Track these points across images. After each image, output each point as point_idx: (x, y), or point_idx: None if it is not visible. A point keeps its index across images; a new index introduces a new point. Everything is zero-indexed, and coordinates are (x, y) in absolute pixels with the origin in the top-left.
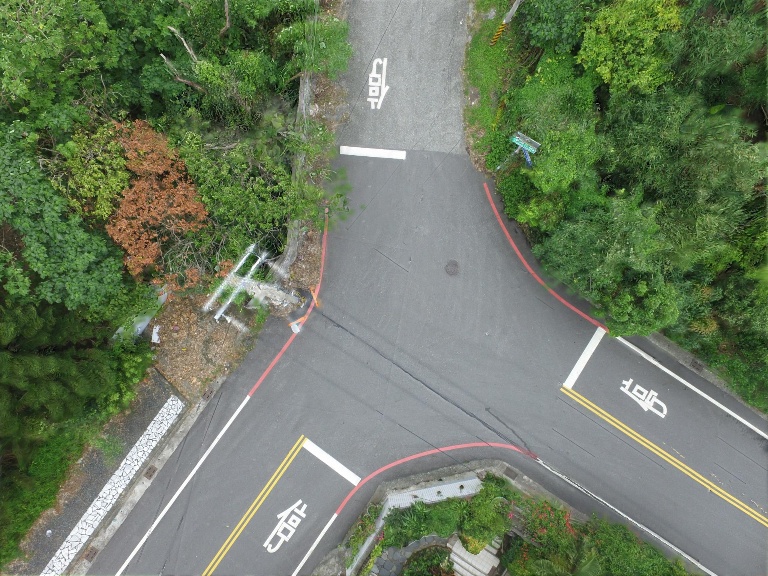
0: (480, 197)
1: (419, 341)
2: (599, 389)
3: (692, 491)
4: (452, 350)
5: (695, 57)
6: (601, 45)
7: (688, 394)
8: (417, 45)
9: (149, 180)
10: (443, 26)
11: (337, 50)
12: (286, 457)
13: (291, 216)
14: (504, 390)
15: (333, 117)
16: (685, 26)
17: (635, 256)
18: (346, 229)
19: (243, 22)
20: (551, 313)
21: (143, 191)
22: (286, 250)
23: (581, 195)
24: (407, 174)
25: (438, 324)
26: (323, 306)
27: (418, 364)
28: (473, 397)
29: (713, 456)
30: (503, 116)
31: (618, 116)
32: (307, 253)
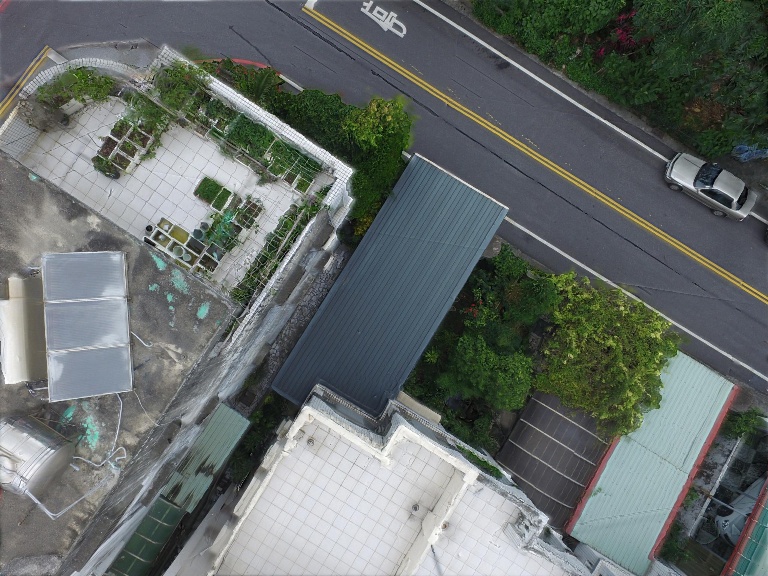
0: None
1: None
2: (340, 10)
3: (430, 105)
4: None
5: None
6: None
7: (427, 16)
8: None
9: None
10: None
11: None
12: (30, 64)
13: None
14: (247, 10)
15: None
16: None
17: None
18: None
19: None
20: None
21: None
22: None
23: None
24: None
25: None
26: None
27: None
28: (217, 16)
29: (450, 73)
30: None
31: None
32: None
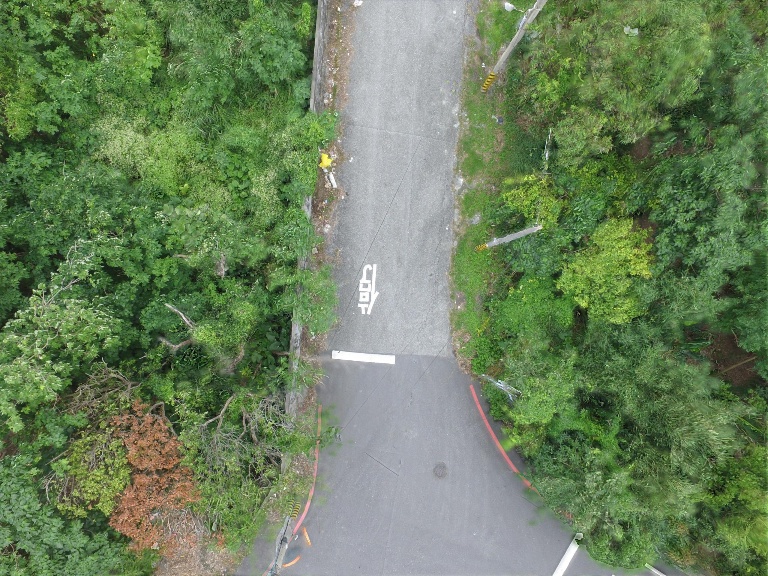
0: (467, 399)
1: (409, 544)
2: None
3: None
4: (441, 551)
5: (666, 306)
6: (578, 281)
7: None
8: (405, 251)
9: (150, 473)
10: (430, 232)
11: (329, 256)
12: None
13: (285, 452)
14: None
15: (325, 322)
16: (656, 276)
17: (610, 521)
18: (338, 433)
19: (238, 254)
20: (536, 511)
21: (144, 484)
22: (280, 478)
23: (561, 423)
24: (396, 378)
25: (427, 526)
26: (317, 510)
27: (408, 567)
28: None
29: None
30: (488, 320)
31: (596, 340)
32: (301, 457)
